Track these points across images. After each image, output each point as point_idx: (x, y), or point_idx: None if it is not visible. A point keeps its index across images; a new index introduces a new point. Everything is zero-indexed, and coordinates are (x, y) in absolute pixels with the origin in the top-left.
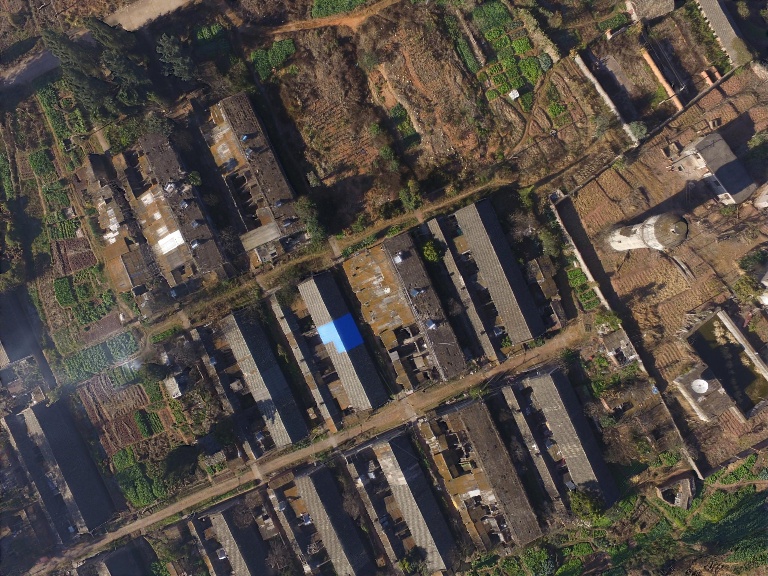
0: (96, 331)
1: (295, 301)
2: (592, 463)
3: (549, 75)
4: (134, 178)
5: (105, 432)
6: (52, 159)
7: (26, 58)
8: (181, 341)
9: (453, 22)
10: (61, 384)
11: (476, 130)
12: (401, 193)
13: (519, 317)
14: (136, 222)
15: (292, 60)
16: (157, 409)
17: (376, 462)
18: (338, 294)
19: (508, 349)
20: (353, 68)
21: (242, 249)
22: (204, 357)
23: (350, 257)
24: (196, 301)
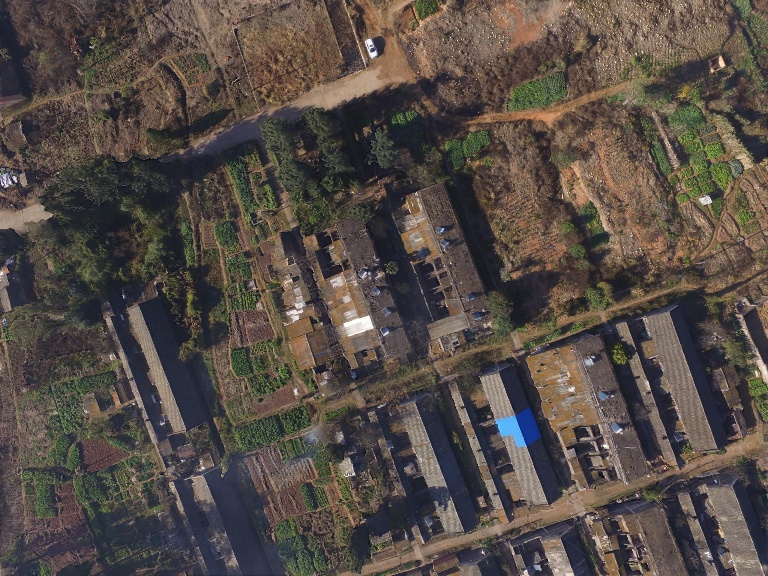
0: (269, 403)
1: (475, 391)
2: (767, 575)
3: (739, 181)
4: (323, 259)
5: (270, 502)
6: (237, 231)
7: (217, 129)
8: (358, 422)
9: (649, 124)
10: (230, 452)
11: (666, 233)
12: (590, 293)
13: (705, 427)
14: (322, 302)
15: (487, 152)
16: (325, 484)
17: (541, 553)
18: (519, 388)
19: (687, 455)
20: (547, 164)
21: (428, 337)
22: (380, 439)
23: (531, 351)
24: (372, 382)
